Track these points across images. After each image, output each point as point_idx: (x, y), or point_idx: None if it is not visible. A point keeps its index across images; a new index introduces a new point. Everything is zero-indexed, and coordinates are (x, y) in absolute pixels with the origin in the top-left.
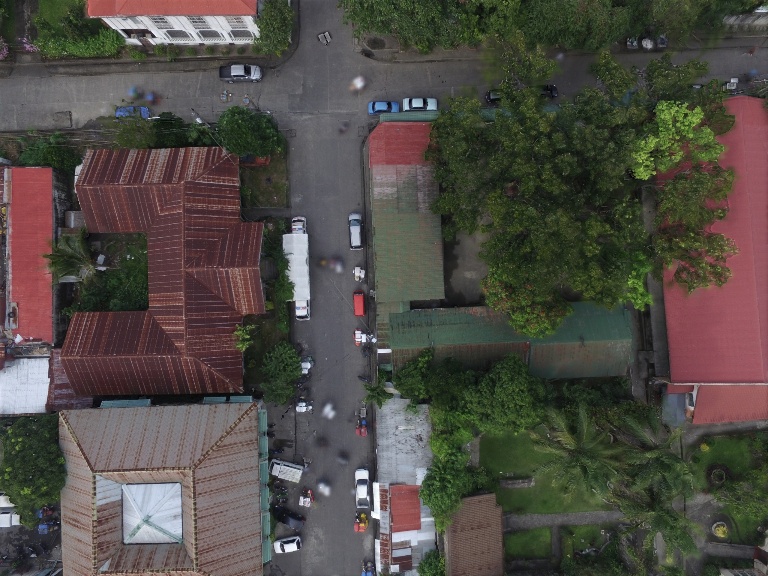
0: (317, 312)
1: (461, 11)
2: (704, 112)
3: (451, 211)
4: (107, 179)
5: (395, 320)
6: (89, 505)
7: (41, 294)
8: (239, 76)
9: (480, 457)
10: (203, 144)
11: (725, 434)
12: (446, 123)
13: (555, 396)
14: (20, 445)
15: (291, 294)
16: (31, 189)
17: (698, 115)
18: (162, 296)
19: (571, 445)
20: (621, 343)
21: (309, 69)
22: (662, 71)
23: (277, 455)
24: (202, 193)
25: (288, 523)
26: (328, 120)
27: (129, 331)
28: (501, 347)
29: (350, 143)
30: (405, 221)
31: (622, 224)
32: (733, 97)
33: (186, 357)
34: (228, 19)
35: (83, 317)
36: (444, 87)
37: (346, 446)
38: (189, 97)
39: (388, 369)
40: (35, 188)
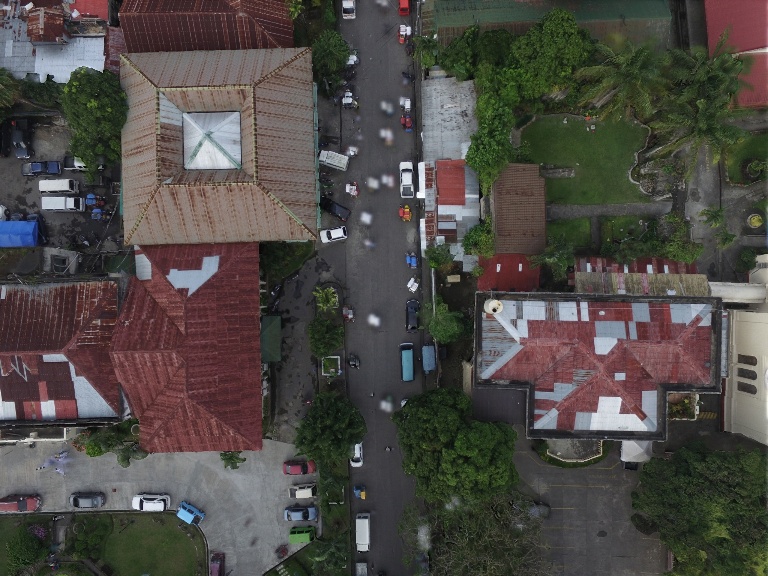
0: (362, 14)
1: None
2: None
3: None
4: None
5: (440, 6)
6: (152, 122)
7: None
8: None
9: None
10: None
11: (760, 130)
12: None
13: None
14: (85, 70)
15: None
16: None
17: None
18: None
19: (620, 58)
20: (661, 22)
21: None
22: None
23: None
24: None
25: (334, 213)
26: None
27: None
28: None
29: None
30: None
31: None
32: None
33: (241, 14)
34: None
35: None
36: None
37: (390, 143)
38: None
39: None
40: None
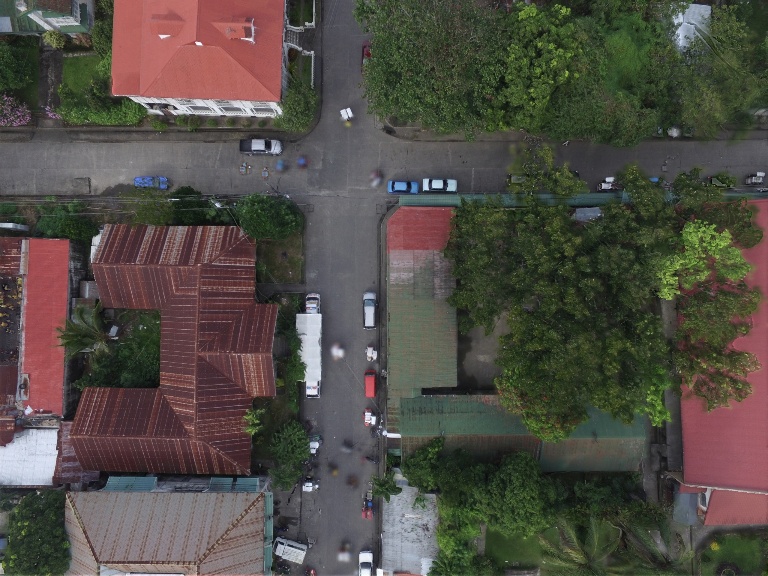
0: (327, 390)
1: (486, 107)
2: (731, 231)
3: (468, 308)
4: (124, 258)
5: (406, 405)
6: None
7: (53, 366)
8: (259, 151)
9: (486, 545)
10: (221, 222)
11: (737, 533)
12: (468, 231)
13: (566, 497)
14: (26, 530)
15: (302, 375)
16: (47, 260)
17: (726, 239)
18: (173, 376)
19: (581, 560)
20: (635, 441)
21: (329, 144)
22: (690, 190)
23: (281, 532)
24: (218, 275)
25: None
26: (346, 196)
27: (139, 410)
28: (512, 439)
29: (368, 220)
30: (420, 307)
31: (643, 340)
32: (760, 200)
33: (195, 441)
34: (251, 101)
35: (94, 393)
36: (465, 168)
37: (351, 526)
38: (208, 168)
39: (397, 454)
40: (51, 259)
